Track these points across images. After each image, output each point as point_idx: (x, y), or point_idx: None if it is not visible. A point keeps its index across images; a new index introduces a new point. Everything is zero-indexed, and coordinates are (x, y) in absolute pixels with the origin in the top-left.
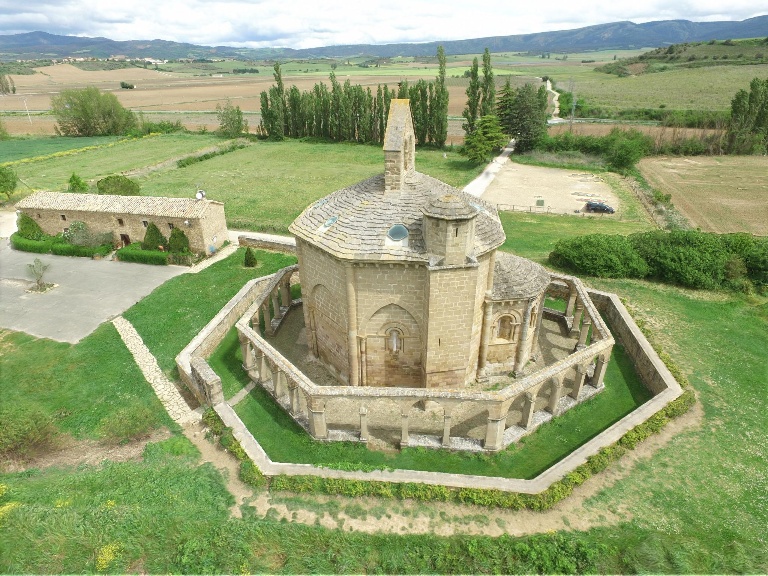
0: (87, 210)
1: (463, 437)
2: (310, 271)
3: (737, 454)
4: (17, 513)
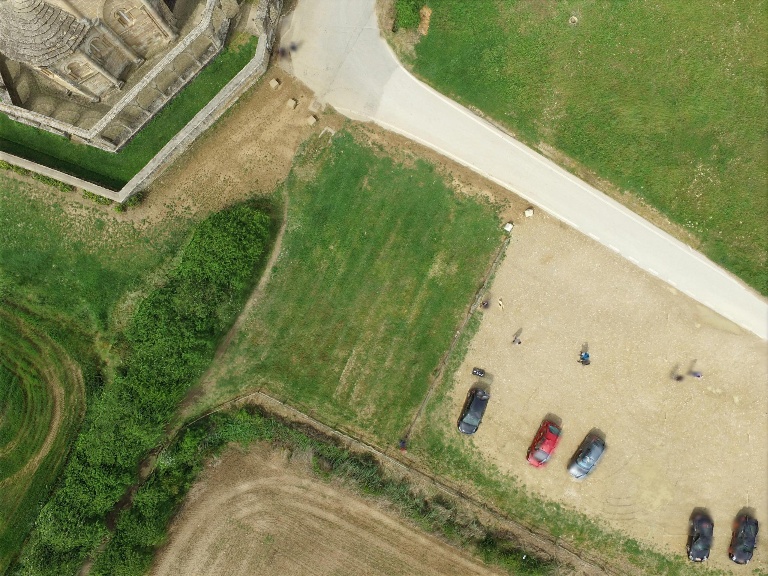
0: None
1: None
2: None
3: None
4: None
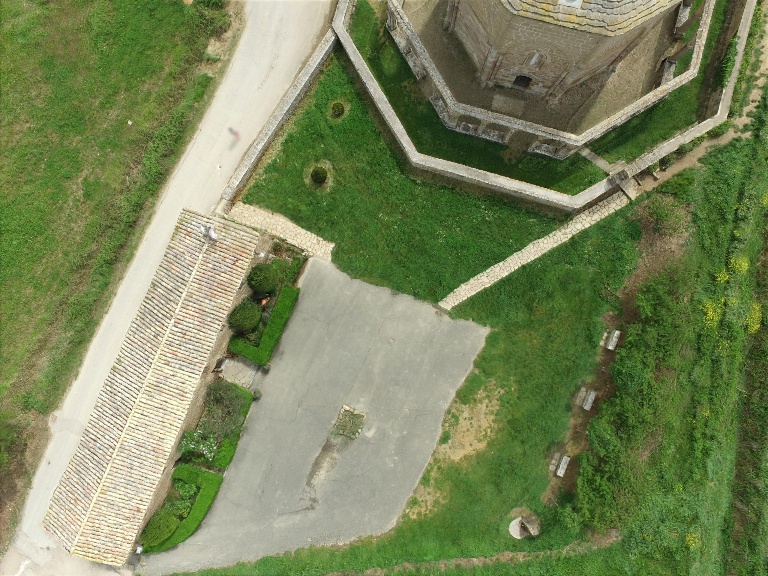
0: (180, 426)
1: None
2: None
3: None
4: None
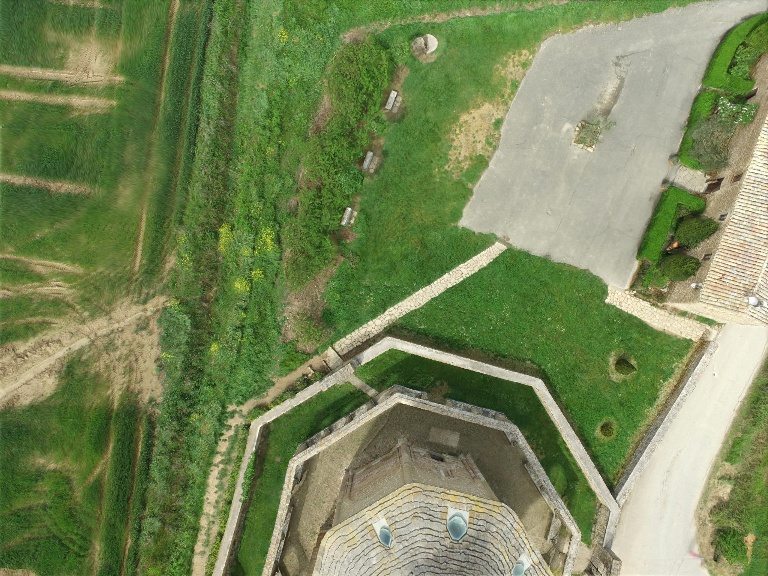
0: (765, 125)
1: (289, 549)
2: (391, 486)
3: None
4: (242, 293)
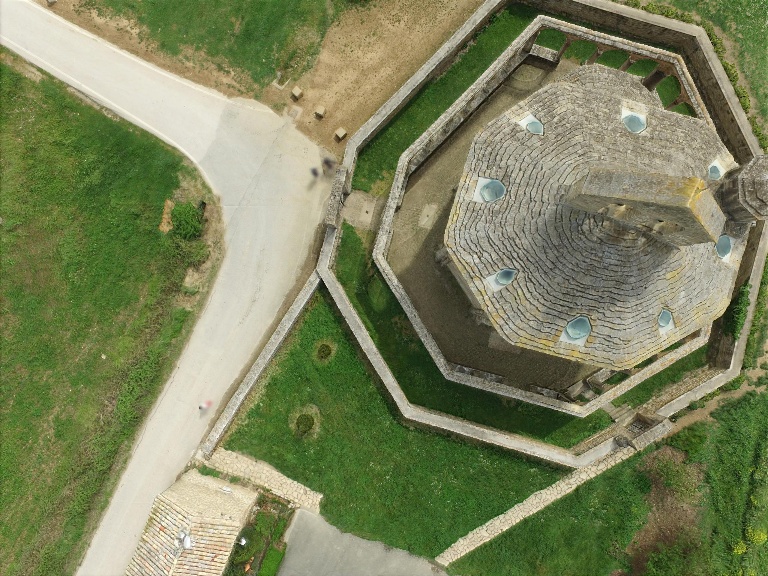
0: None
1: None
2: None
3: (766, 39)
4: None
